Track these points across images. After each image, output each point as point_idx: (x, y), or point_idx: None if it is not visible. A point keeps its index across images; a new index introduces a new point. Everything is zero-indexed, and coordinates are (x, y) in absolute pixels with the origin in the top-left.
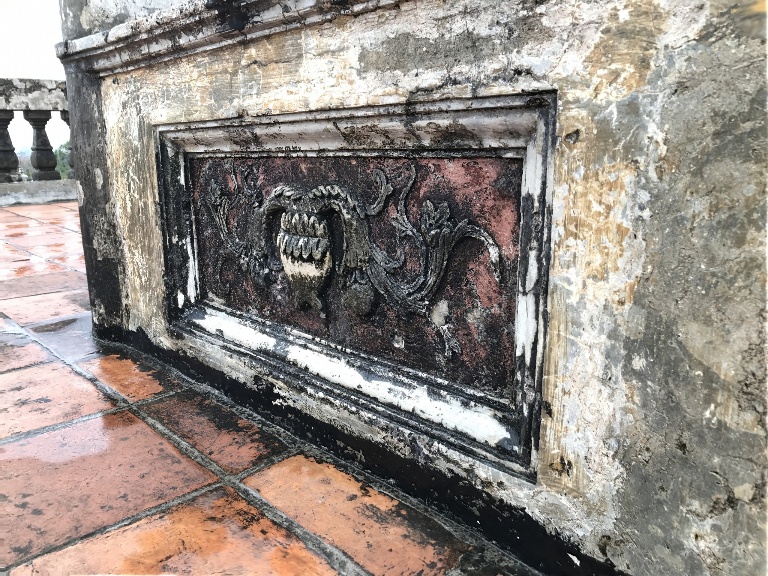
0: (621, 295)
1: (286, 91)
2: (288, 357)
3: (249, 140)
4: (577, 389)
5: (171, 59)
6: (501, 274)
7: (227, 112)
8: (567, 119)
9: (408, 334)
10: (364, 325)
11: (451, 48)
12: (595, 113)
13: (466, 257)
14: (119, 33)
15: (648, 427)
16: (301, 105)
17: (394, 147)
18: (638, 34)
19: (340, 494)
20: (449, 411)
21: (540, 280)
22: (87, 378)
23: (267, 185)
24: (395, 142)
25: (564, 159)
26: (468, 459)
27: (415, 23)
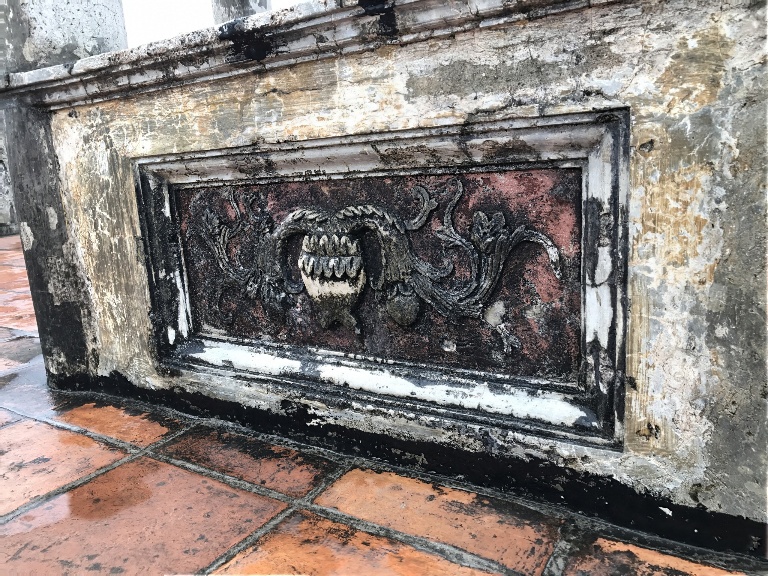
0: (702, 276)
1: (316, 117)
2: (321, 377)
3: (260, 167)
4: (661, 362)
5: (158, 90)
6: (561, 271)
7: (237, 140)
8: (641, 131)
9: (460, 337)
10: (407, 335)
11: (514, 73)
12: (669, 125)
13: (523, 260)
14: (90, 64)
15: (733, 384)
16: (336, 130)
17: (440, 165)
18: (707, 59)
19: (418, 497)
20: (517, 402)
21: (614, 272)
22: (74, 431)
23: (279, 210)
24: (442, 160)
25: (639, 165)
26: (548, 441)
27: (472, 51)
